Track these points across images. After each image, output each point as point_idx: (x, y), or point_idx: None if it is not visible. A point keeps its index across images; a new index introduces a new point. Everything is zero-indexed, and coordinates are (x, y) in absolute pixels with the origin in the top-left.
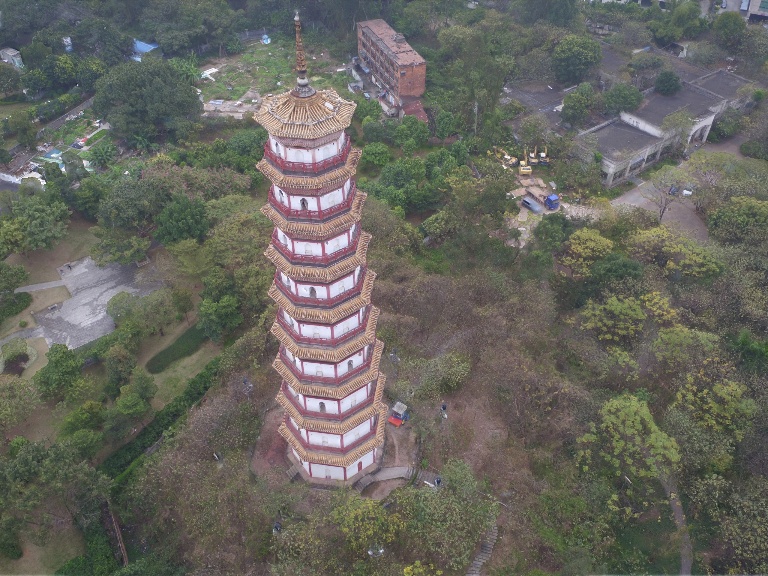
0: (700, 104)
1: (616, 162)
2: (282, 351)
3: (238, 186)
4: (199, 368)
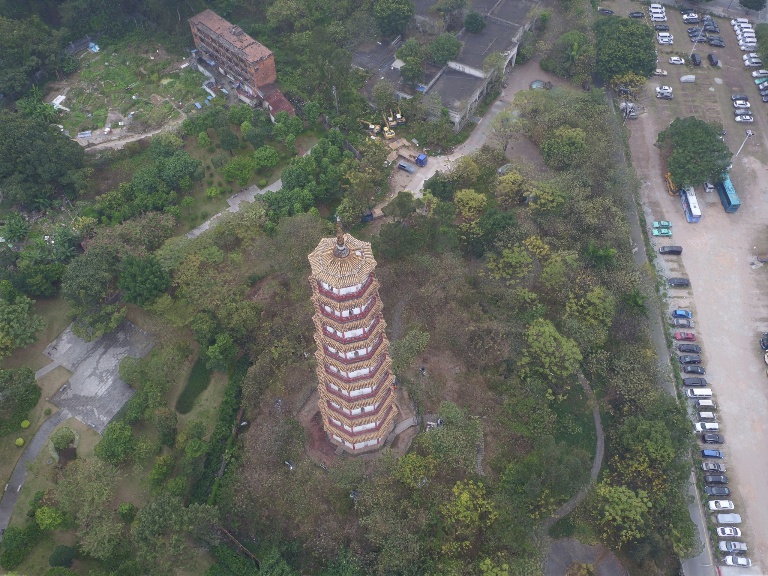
0: (504, 36)
1: (460, 113)
2: (327, 386)
3: (166, 226)
4: (218, 396)
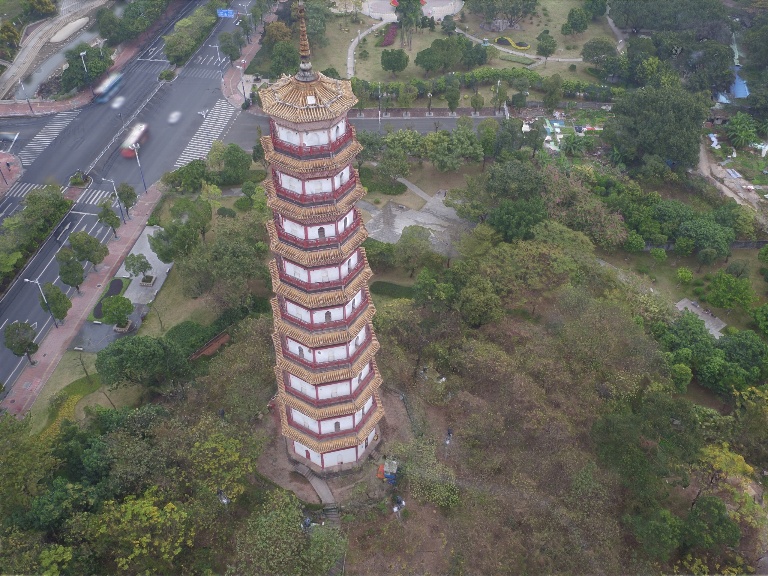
0: None
1: None
2: None
3: (607, 235)
4: None
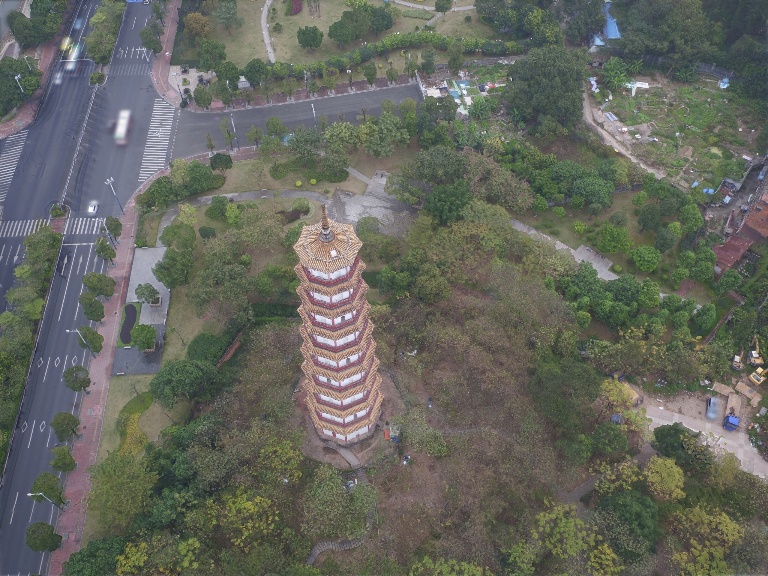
0: None
1: None
2: None
3: None
4: None
